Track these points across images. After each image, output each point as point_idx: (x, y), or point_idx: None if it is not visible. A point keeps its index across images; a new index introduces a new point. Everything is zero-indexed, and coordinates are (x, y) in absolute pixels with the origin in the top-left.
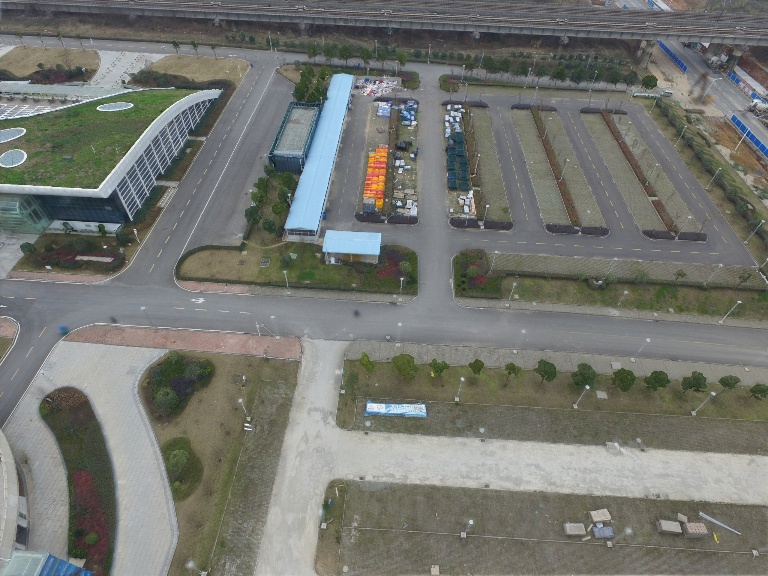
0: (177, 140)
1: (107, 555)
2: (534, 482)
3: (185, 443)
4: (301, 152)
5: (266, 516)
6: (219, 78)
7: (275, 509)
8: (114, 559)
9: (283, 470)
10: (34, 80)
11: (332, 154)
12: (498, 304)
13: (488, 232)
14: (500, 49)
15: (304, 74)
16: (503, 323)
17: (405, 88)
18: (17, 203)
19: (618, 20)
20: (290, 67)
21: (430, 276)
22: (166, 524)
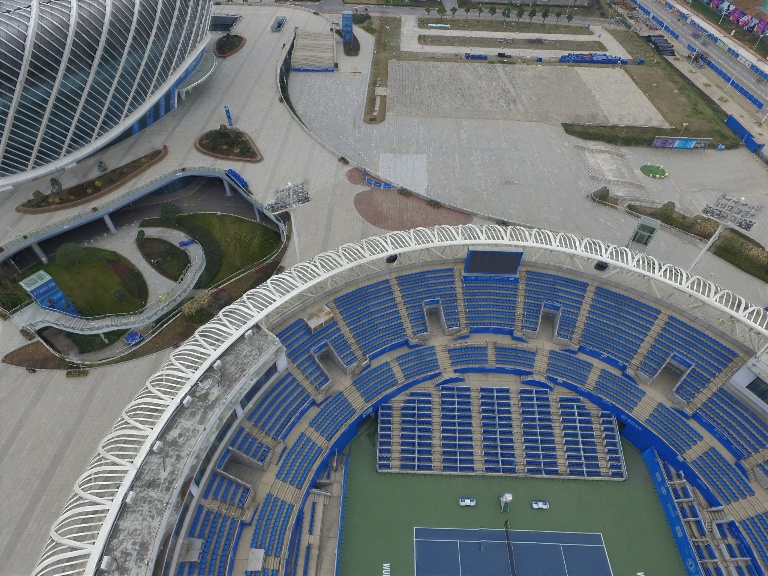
0: None
1: None
2: (488, 36)
3: None
4: None
5: (400, 38)
6: None
7: None
8: None
9: (403, 33)
10: None
11: None
12: (476, 10)
13: None
14: None
15: None
16: (478, 13)
17: None
18: None
19: None
20: None
21: (448, 4)
22: (370, 36)
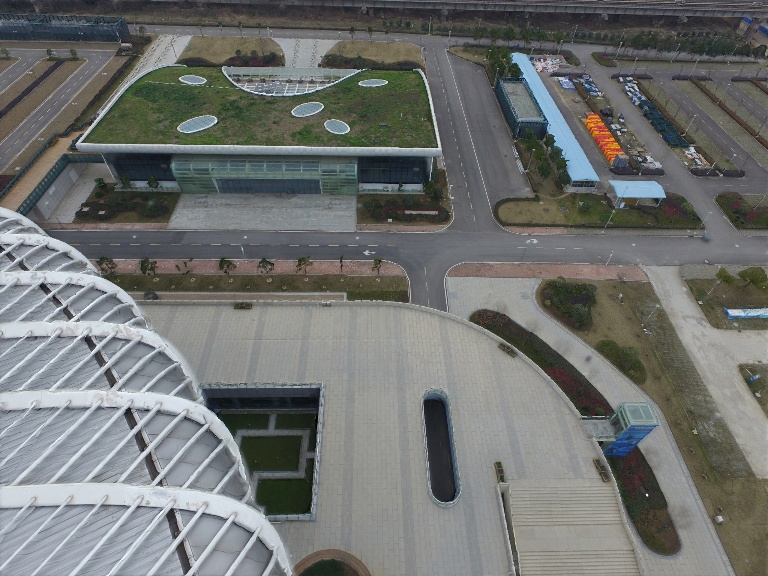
0: None
1: None
2: None
3: (614, 344)
4: (543, 118)
5: (708, 392)
6: (403, 60)
7: (711, 387)
8: None
9: (696, 360)
10: (236, 66)
11: (563, 120)
12: None
13: (727, 179)
14: (626, 29)
15: (494, 53)
16: None
17: (570, 64)
18: (355, 165)
19: (729, 0)
20: (457, 49)
21: (706, 214)
22: (643, 400)
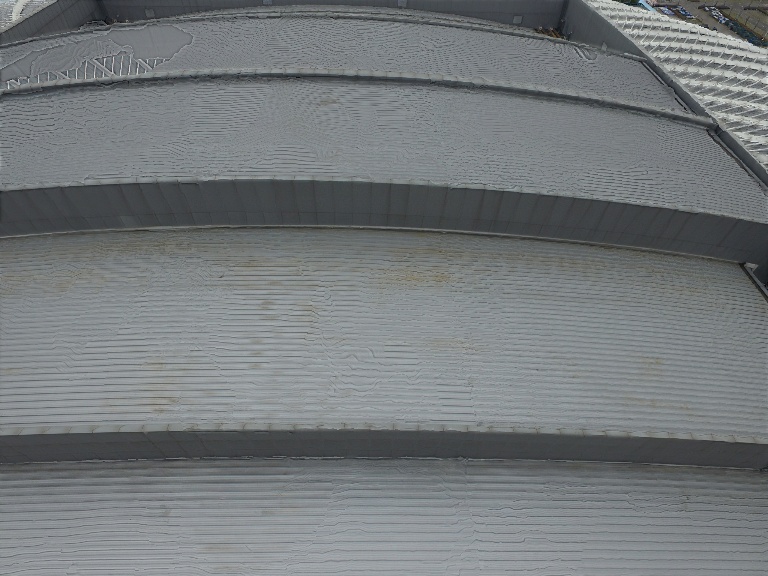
0: None
1: None
2: None
3: None
4: None
5: None
6: None
7: None
8: None
9: None
10: None
11: None
12: None
13: None
14: None
15: None
16: None
17: (665, 0)
18: None
19: None
20: None
21: None
22: None
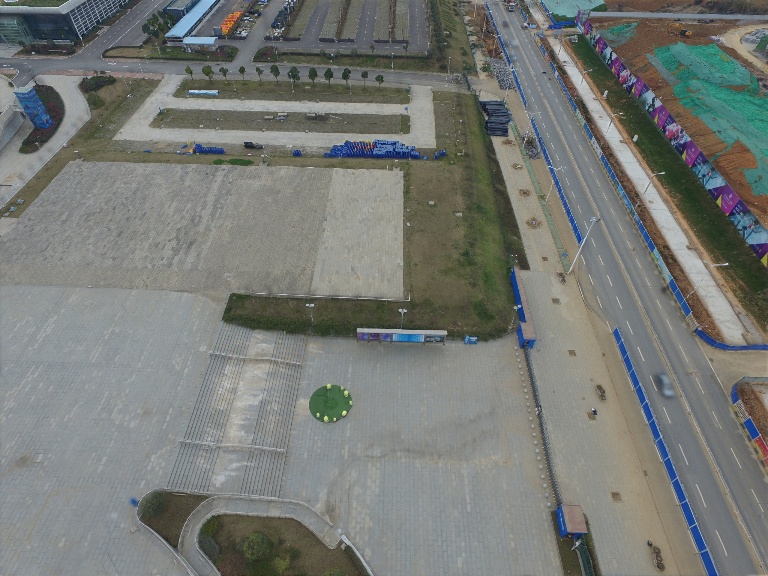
0: (110, 6)
1: (59, 119)
2: (259, 109)
3: (98, 97)
4: (183, 8)
5: (132, 116)
6: None
7: (136, 114)
8: (62, 121)
9: (143, 106)
10: None
11: (203, 11)
12: None
13: (284, 42)
14: None
15: None
16: None
17: None
18: (15, 20)
19: None
20: None
21: (242, 56)
22: (86, 115)
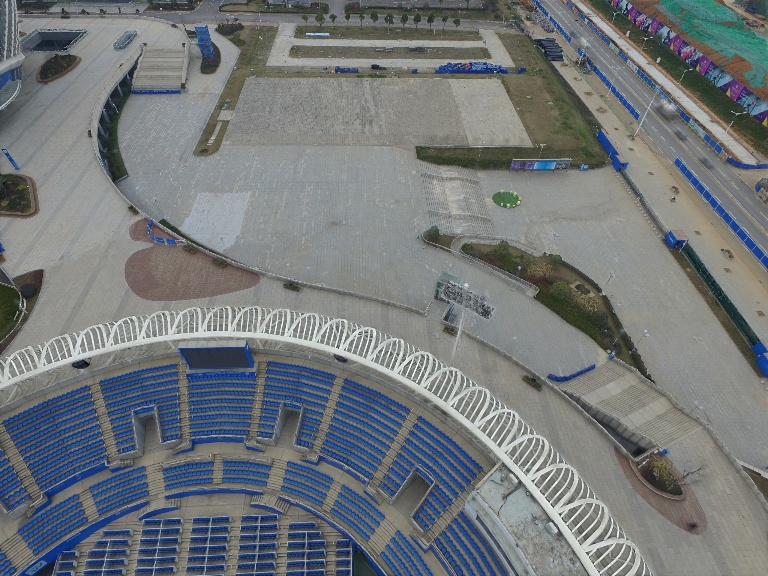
0: None
1: None
2: (368, 45)
3: None
4: None
5: None
6: None
7: None
8: (220, 53)
9: None
10: None
11: None
12: (363, 15)
13: (363, 0)
14: None
15: None
16: (364, 19)
17: None
18: None
19: None
20: None
21: (334, 10)
22: (236, 49)
